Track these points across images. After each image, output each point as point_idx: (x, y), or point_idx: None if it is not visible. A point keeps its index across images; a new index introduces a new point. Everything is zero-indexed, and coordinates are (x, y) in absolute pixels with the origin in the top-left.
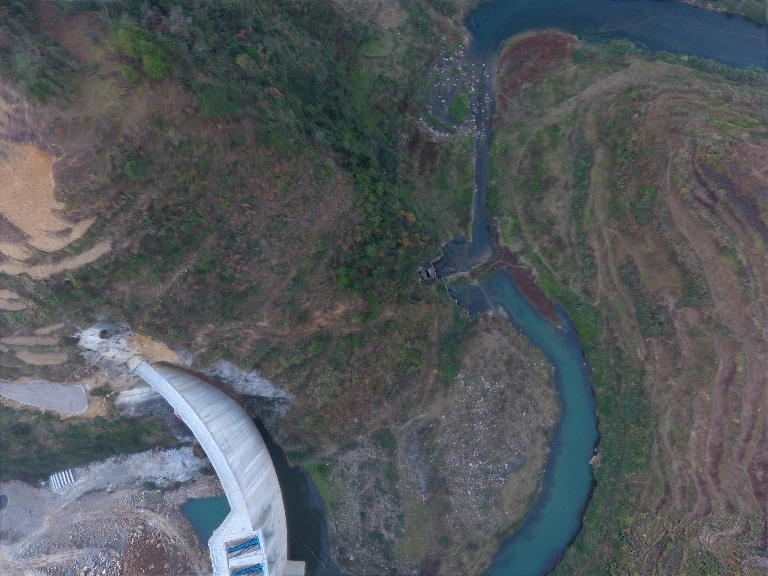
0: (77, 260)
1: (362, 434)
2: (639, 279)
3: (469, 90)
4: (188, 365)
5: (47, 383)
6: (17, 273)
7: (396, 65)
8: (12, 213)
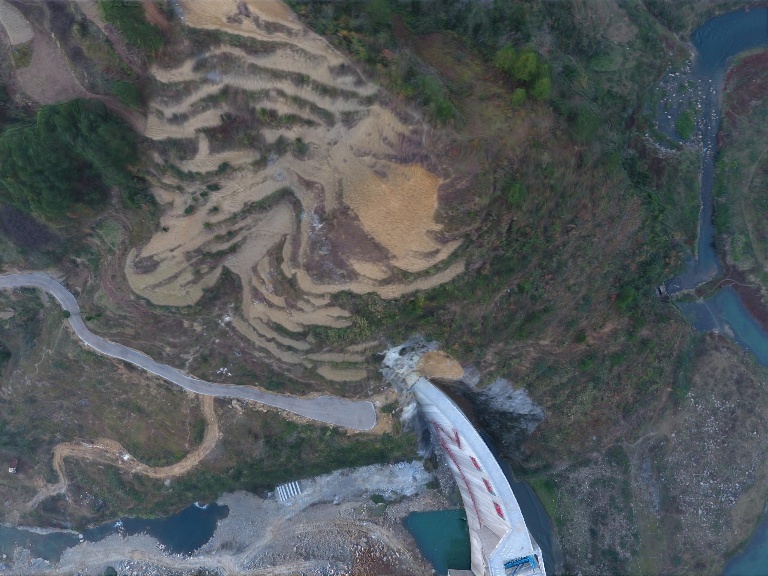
0: (431, 280)
1: (597, 451)
2: None
3: (695, 106)
4: (474, 383)
5: (336, 399)
6: (366, 292)
7: (625, 80)
8: (381, 233)
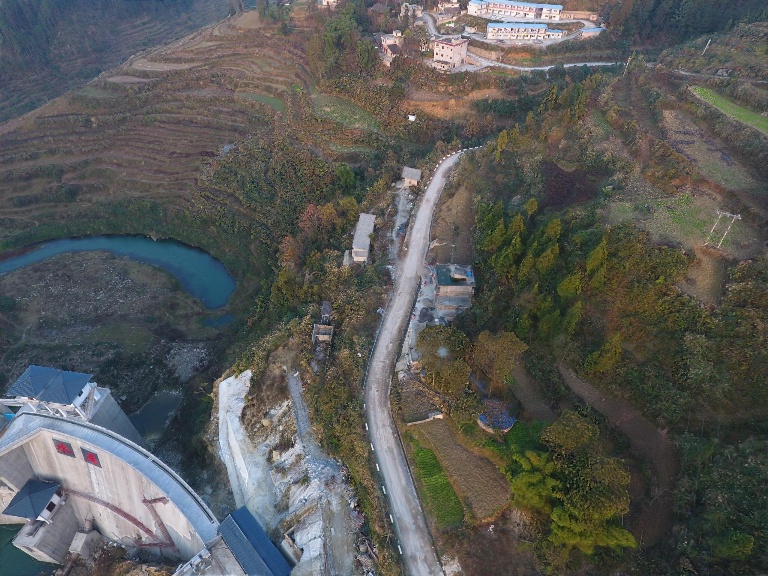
0: None
1: None
2: (28, 196)
3: None
4: None
5: None
6: None
7: None
8: None
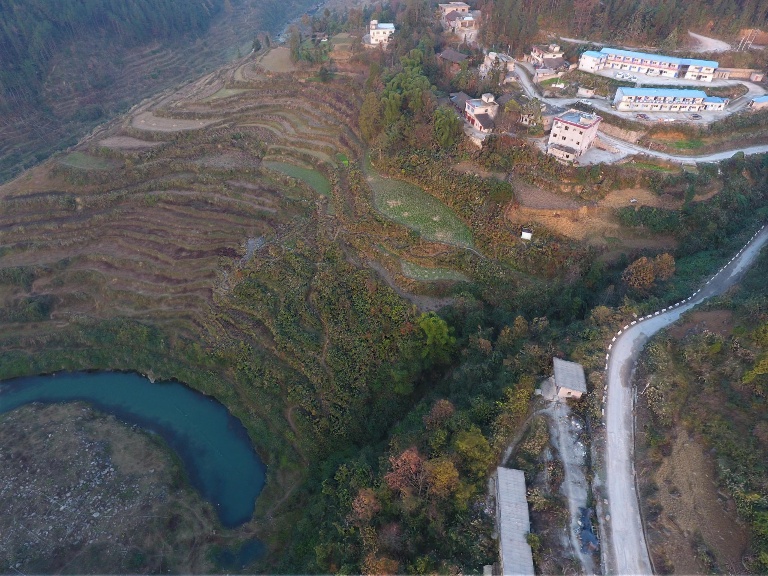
0: None
1: None
2: None
3: None
4: None
5: None
6: None
7: None
8: None
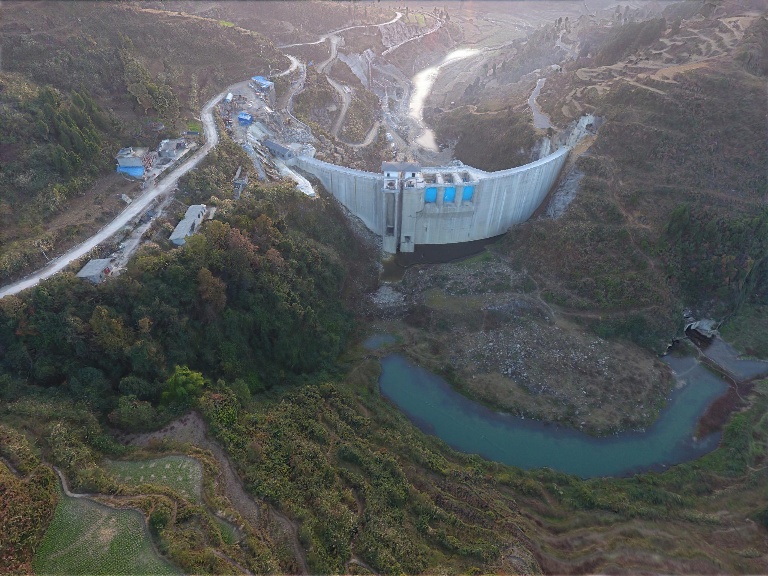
0: None
1: None
2: None
3: None
4: None
5: (548, 119)
6: None
7: None
8: None
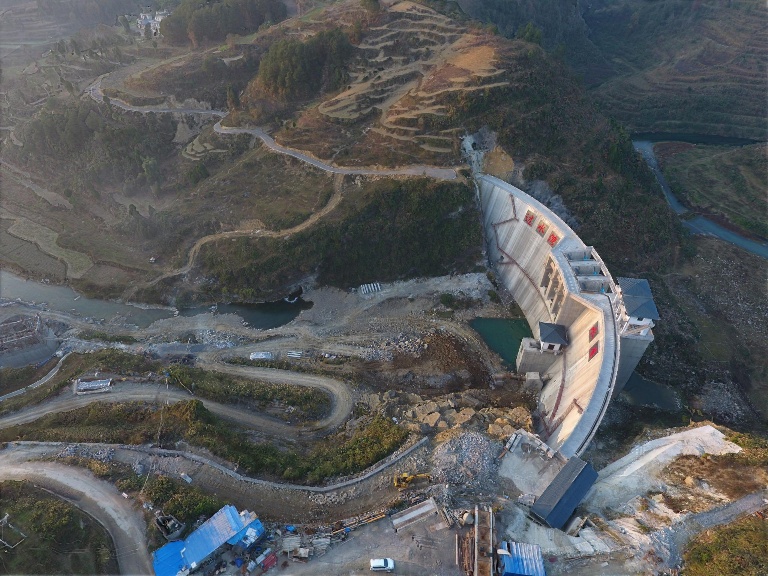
0: None
1: (632, 272)
2: None
3: None
4: (522, 170)
5: (429, 167)
6: (457, 89)
7: None
8: (466, 66)
